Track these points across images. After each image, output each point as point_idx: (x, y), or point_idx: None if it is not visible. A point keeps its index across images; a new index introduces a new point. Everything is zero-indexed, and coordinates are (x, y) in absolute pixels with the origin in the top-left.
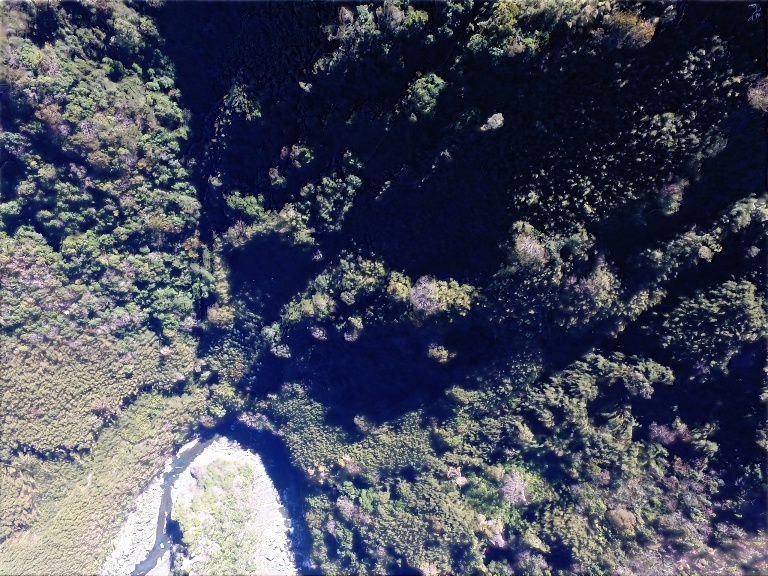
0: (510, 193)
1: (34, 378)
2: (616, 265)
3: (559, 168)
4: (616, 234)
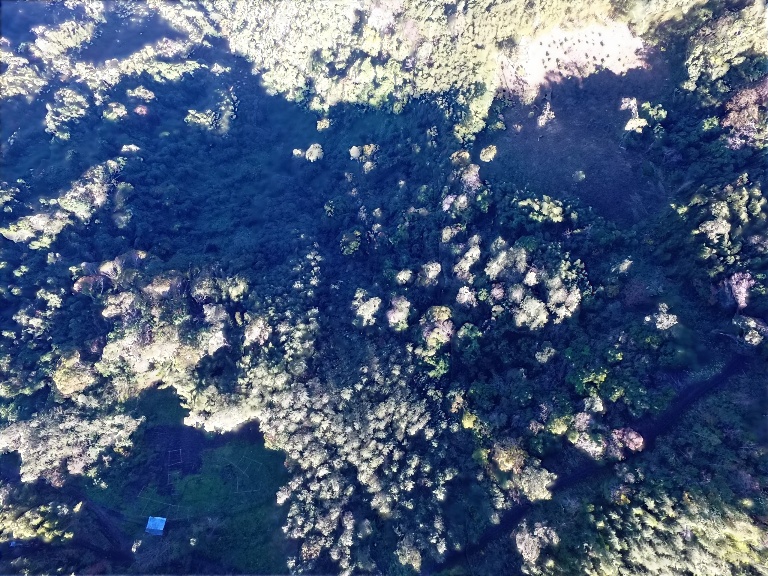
0: None
1: None
2: None
3: None
4: None
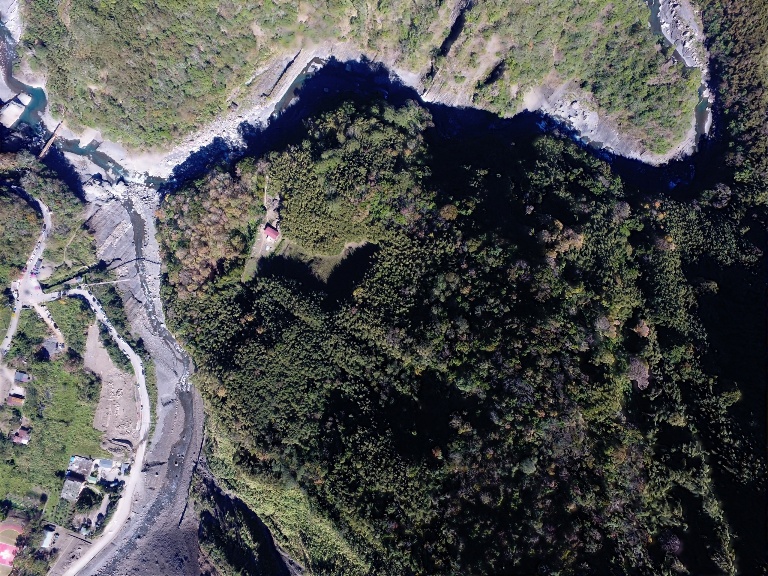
0: None
1: None
2: None
3: None
4: None
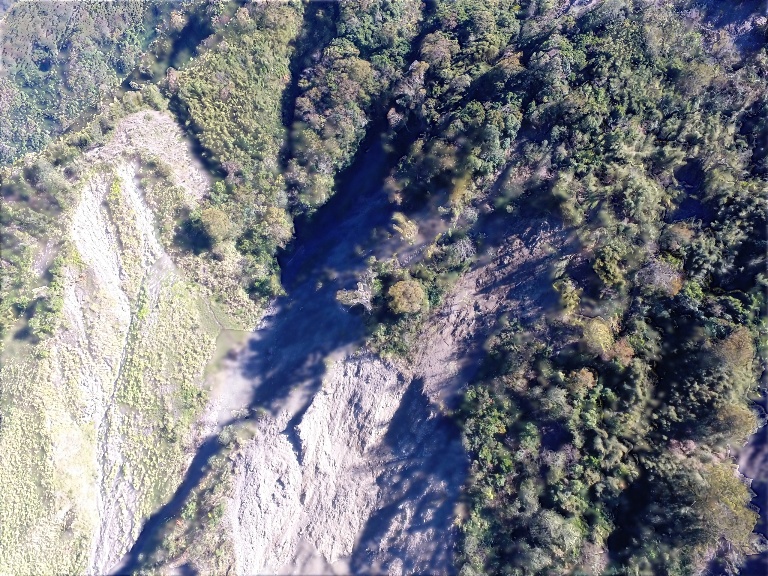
0: None
1: None
2: None
3: None
4: None
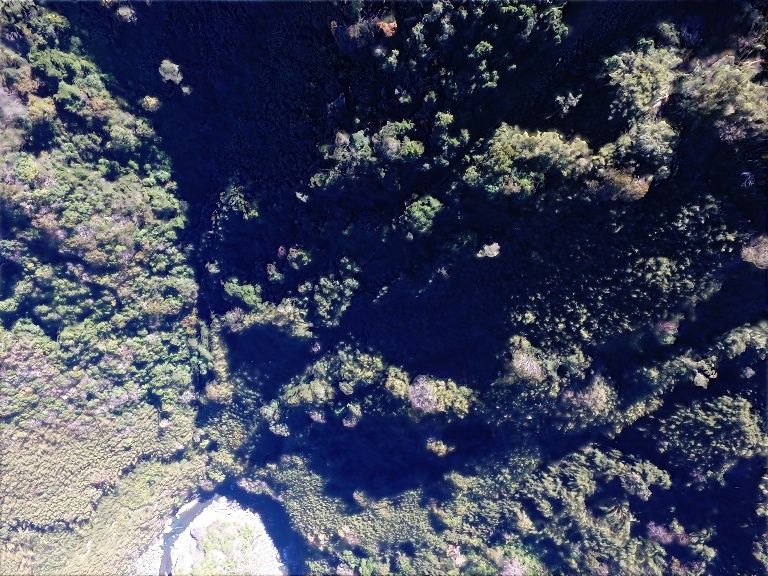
0: (507, 310)
1: (33, 460)
2: (613, 379)
3: (555, 293)
4: (612, 350)
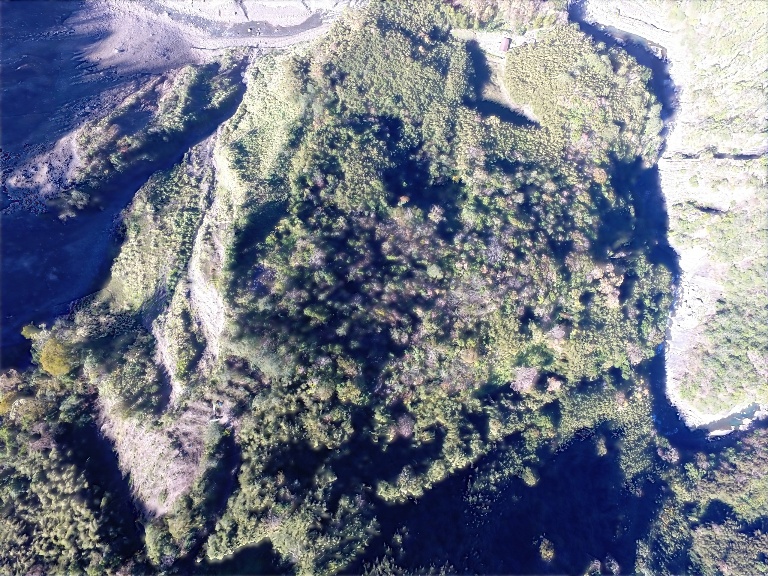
0: None
1: None
2: None
3: None
4: None
